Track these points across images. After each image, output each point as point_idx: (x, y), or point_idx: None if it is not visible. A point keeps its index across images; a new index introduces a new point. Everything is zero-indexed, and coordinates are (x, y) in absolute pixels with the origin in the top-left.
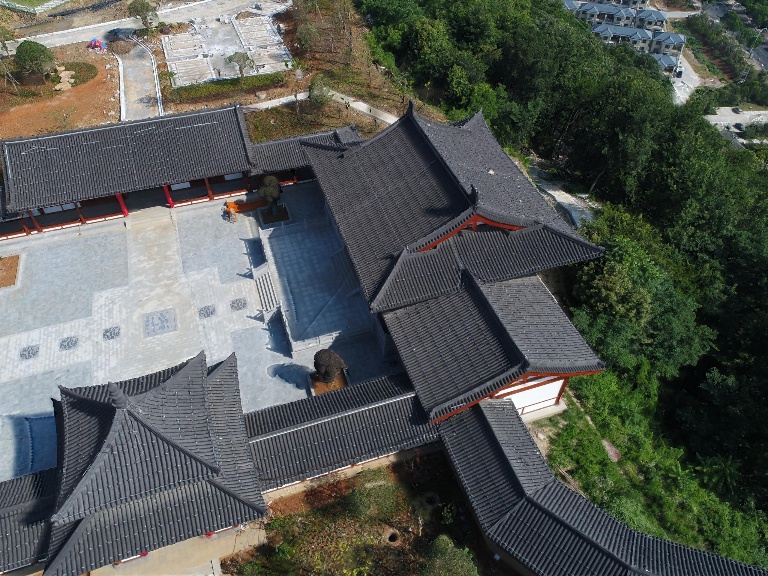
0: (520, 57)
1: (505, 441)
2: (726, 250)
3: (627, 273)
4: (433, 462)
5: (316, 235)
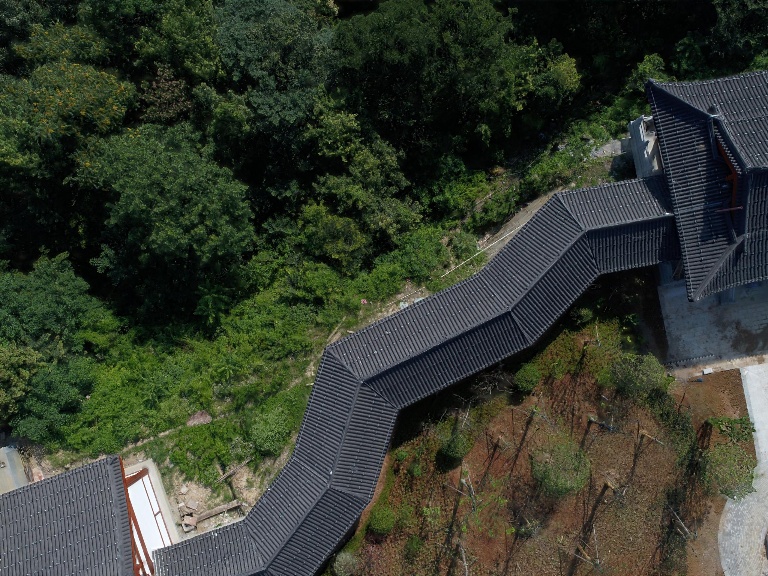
0: None
1: (206, 575)
2: None
3: None
4: None
5: None
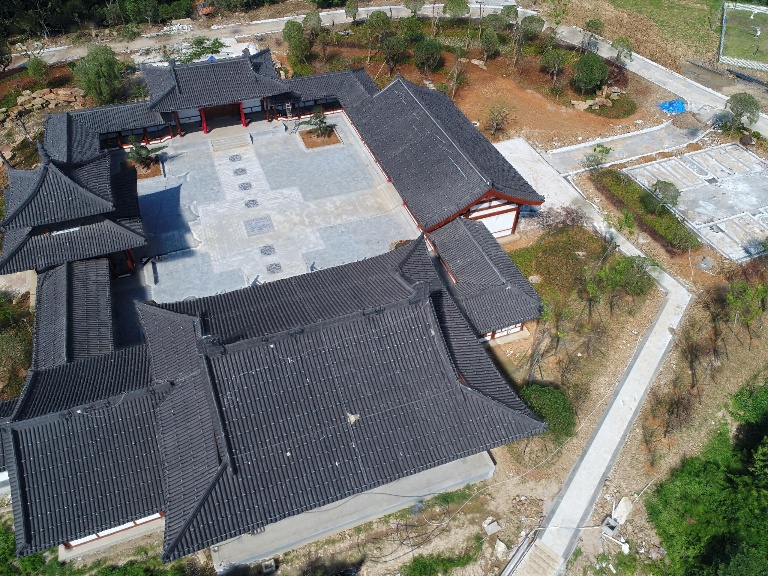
0: None
1: None
2: None
3: None
4: None
5: None
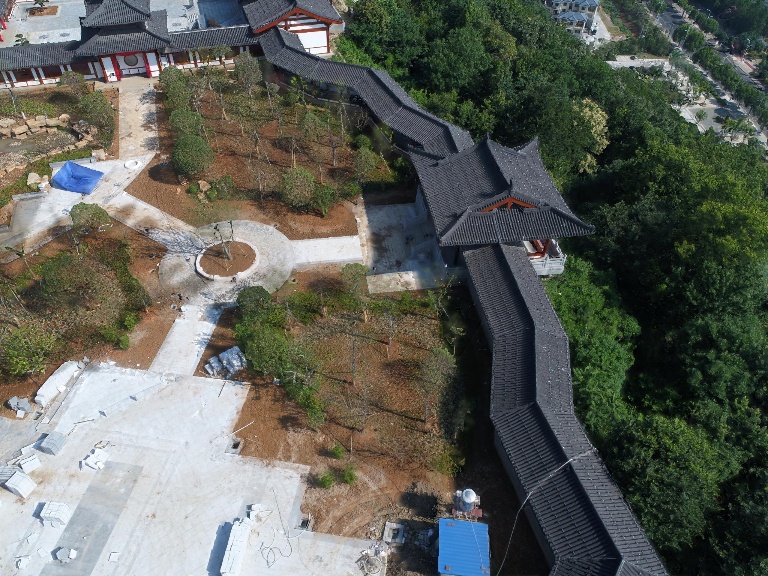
0: None
1: (286, 38)
2: (449, 11)
3: (379, 5)
4: (261, 68)
5: (225, 2)
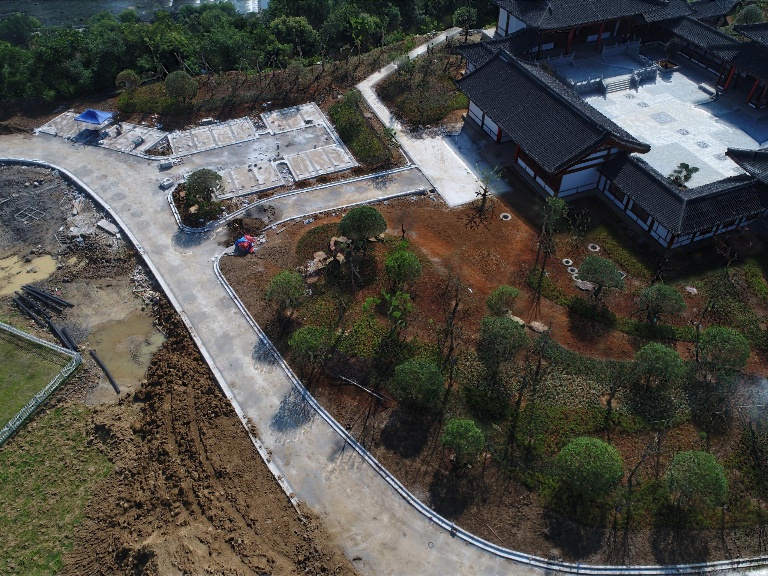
0: (326, 4)
1: None
2: None
3: None
4: None
5: None
